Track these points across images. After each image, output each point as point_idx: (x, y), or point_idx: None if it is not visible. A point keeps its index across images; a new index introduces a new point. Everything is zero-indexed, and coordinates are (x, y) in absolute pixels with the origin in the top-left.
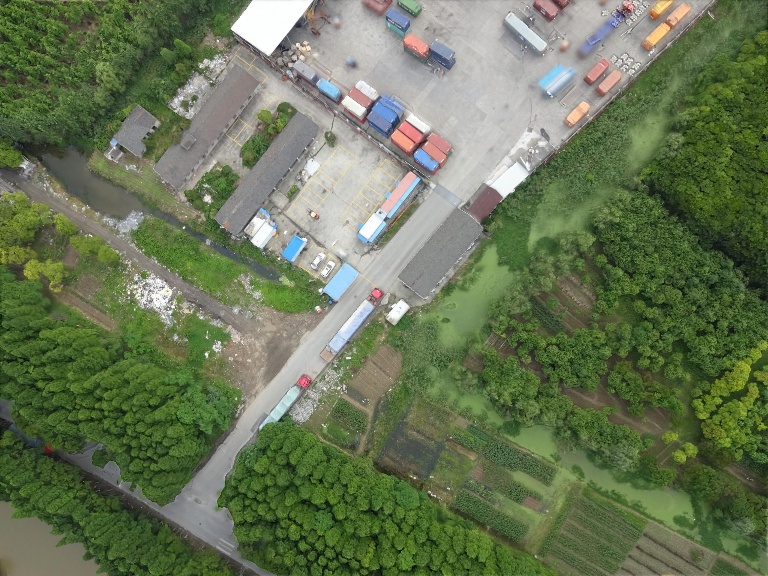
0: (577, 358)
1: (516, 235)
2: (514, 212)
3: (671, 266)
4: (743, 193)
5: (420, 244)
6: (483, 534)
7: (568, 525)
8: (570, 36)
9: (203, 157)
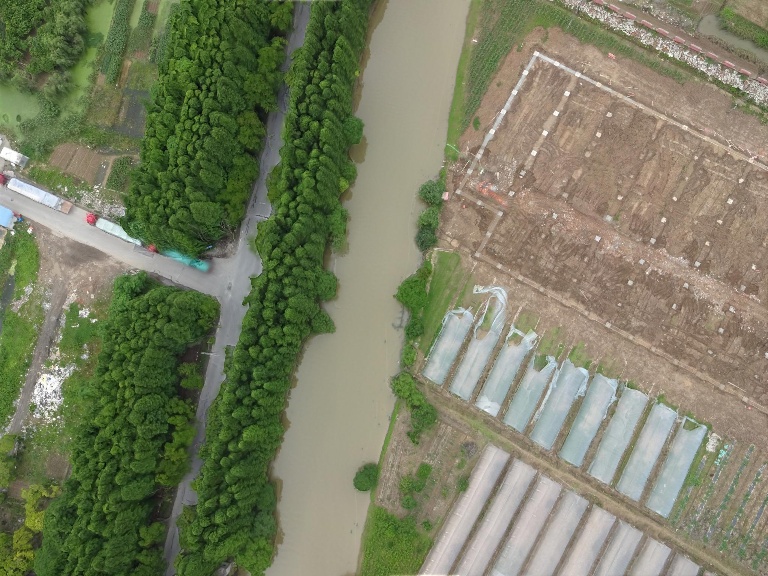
0: (16, 1)
1: None
2: None
3: None
4: None
5: None
6: None
7: None
8: None
9: None
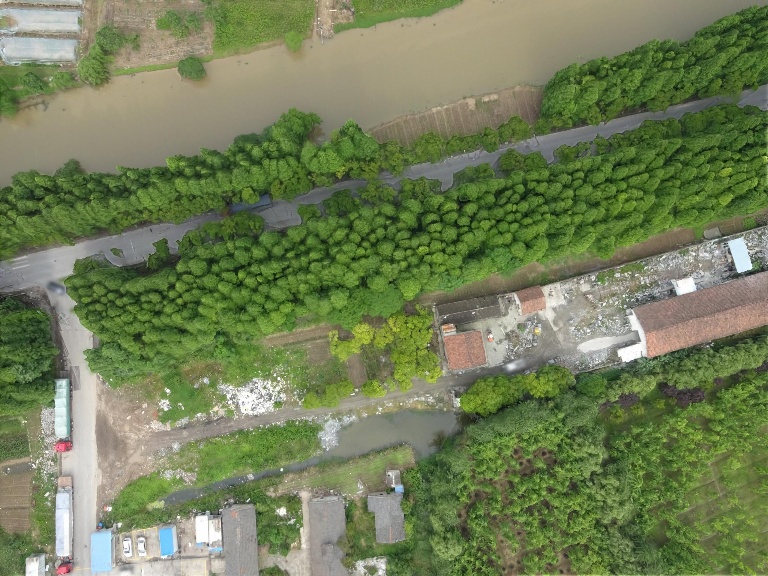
0: None
1: None
2: None
3: None
4: None
5: None
6: None
7: None
8: None
9: None
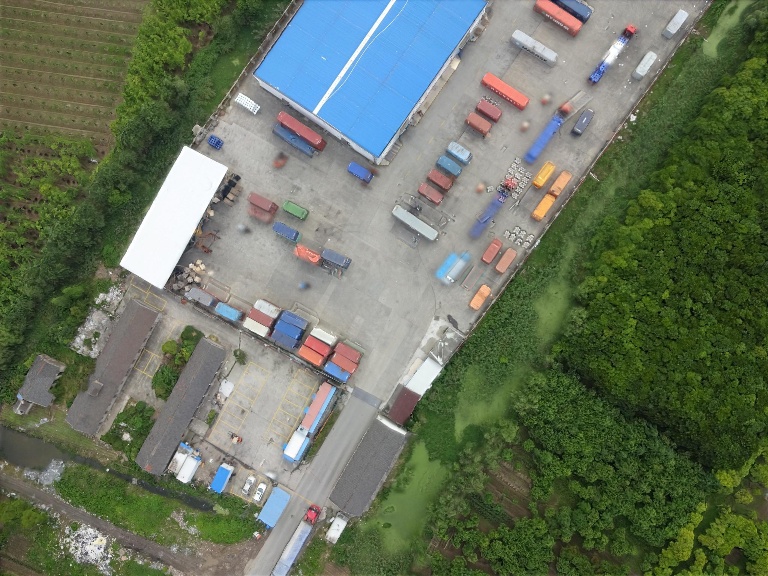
0: (522, 550)
1: (441, 427)
2: (435, 406)
3: (598, 443)
4: (654, 363)
5: (348, 452)
6: None
7: None
8: (460, 217)
9: (114, 397)
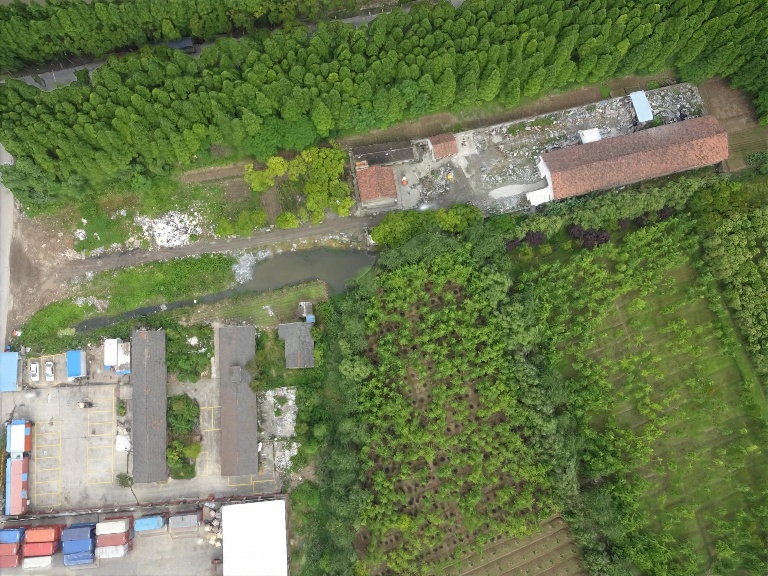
0: None
1: None
2: None
3: None
4: None
5: None
6: None
7: None
8: None
9: None
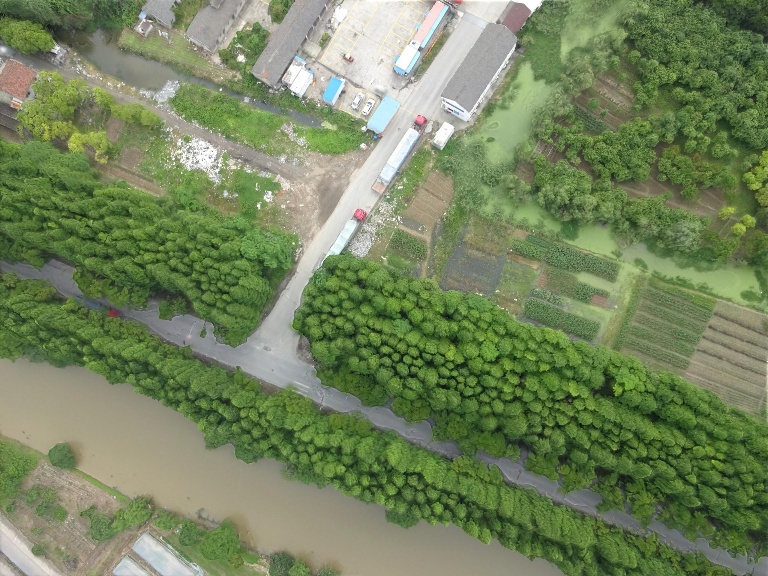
0: (625, 150)
1: (548, 49)
2: (543, 26)
3: (704, 49)
4: None
5: None
6: (558, 331)
7: (638, 316)
8: None
9: (232, 18)
